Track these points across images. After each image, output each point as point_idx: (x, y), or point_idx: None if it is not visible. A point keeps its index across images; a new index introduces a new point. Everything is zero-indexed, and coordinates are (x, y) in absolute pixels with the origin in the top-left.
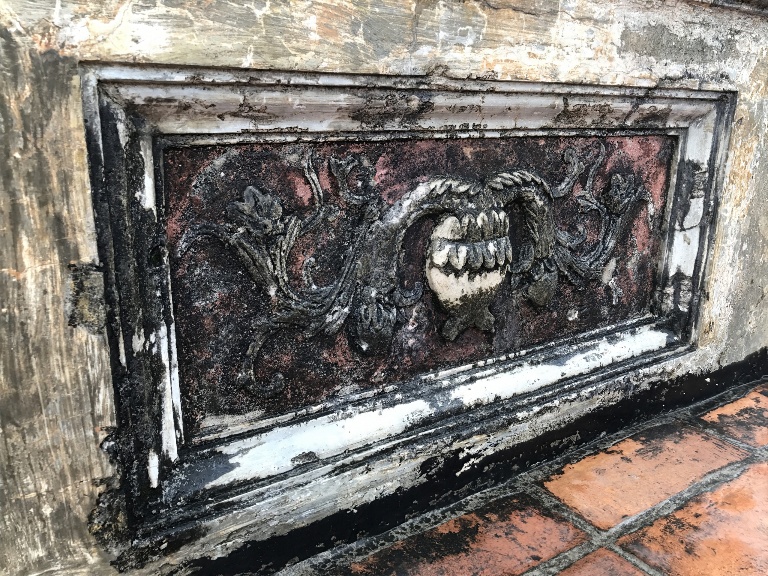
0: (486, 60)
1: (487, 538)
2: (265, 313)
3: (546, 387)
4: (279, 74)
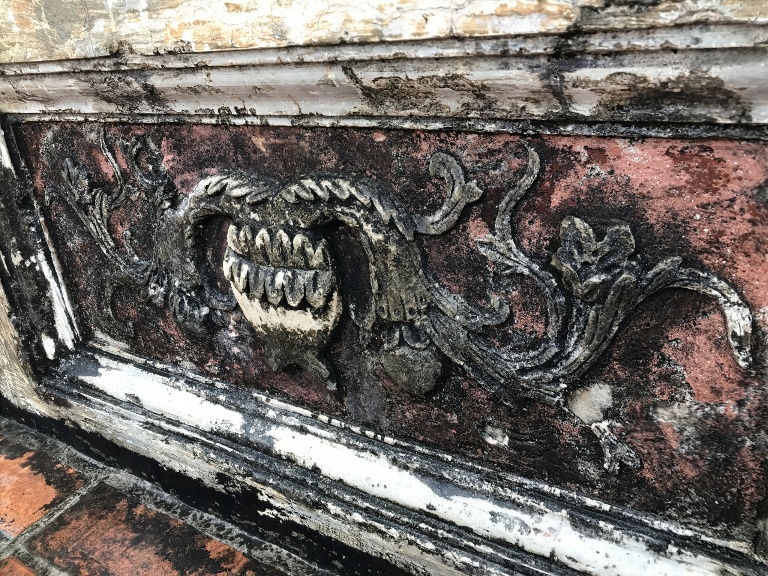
0: (169, 26)
1: None
2: (110, 267)
3: (396, 504)
4: (13, 66)
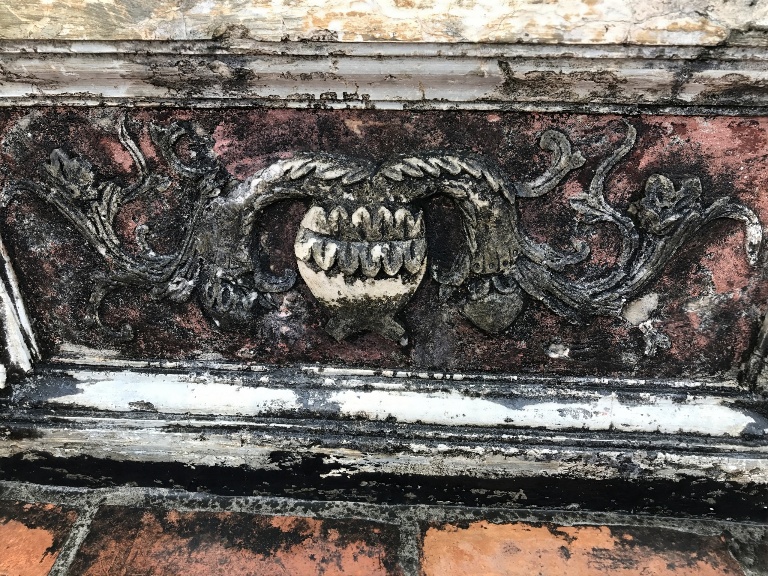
0: (312, 15)
1: (300, 554)
2: (103, 269)
3: (475, 427)
4: (21, 42)
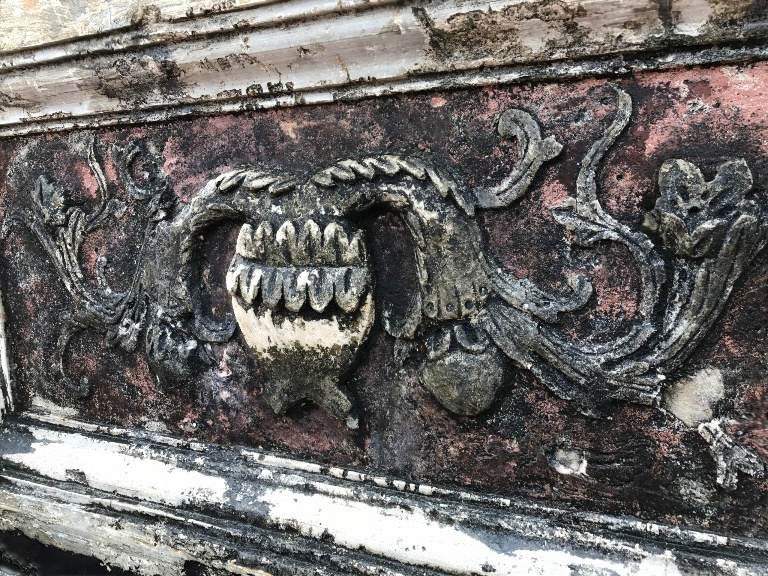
0: None
1: None
2: (70, 308)
3: (439, 572)
4: (3, 58)
